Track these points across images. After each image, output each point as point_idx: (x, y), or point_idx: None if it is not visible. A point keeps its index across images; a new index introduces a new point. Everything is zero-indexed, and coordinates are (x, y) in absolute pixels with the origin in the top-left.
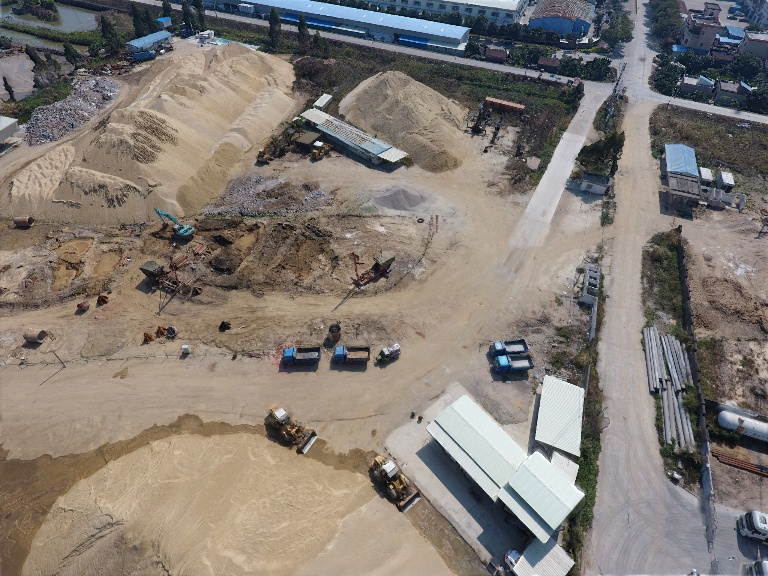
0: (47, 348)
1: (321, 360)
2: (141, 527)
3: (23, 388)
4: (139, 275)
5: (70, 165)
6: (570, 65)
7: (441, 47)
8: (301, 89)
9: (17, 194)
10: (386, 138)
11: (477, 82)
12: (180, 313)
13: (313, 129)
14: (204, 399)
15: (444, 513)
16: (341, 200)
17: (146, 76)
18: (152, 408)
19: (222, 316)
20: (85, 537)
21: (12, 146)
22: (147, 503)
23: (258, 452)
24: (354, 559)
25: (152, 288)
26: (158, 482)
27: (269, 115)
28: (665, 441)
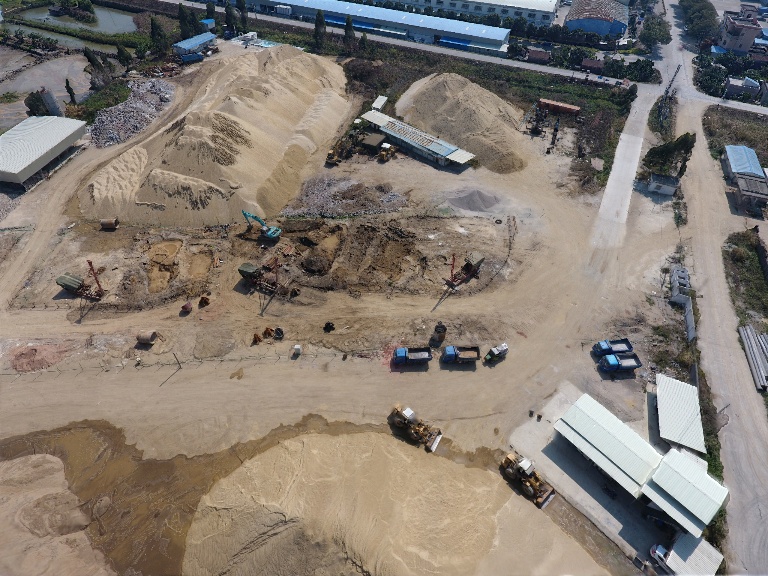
0: (159, 349)
1: (430, 360)
2: (319, 524)
3: (144, 389)
4: (234, 276)
5: (147, 167)
6: (615, 66)
7: (483, 48)
8: (354, 91)
9: (99, 196)
10: (449, 140)
11: (525, 83)
12: (282, 314)
13: (374, 131)
14: (324, 399)
15: (581, 509)
16: (416, 201)
17: (198, 78)
18: (275, 408)
19: (324, 317)
20: (255, 535)
21: (81, 148)
22: (313, 501)
23: (392, 451)
24: (521, 554)
25: (251, 289)
26: (313, 480)
27: (329, 117)
28: None
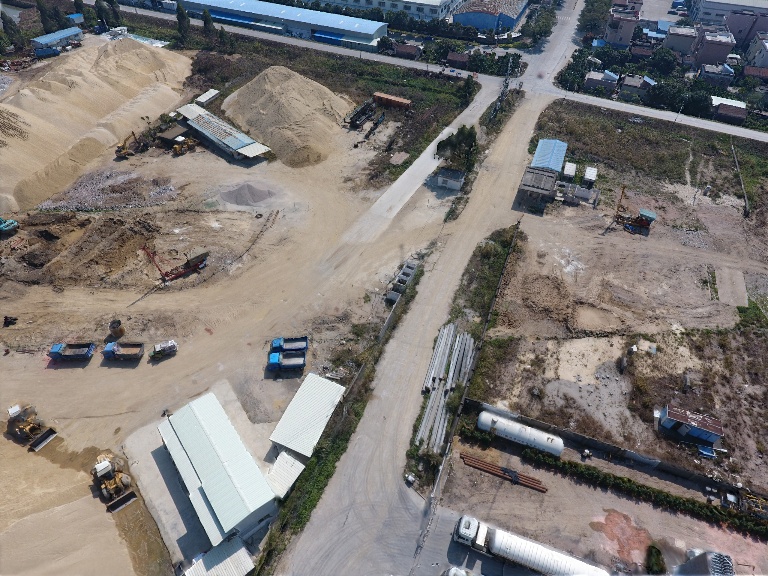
0: None
1: (94, 356)
2: None
3: None
4: None
5: None
6: (477, 60)
7: (354, 43)
8: (193, 84)
9: None
10: (257, 133)
11: (377, 77)
12: None
13: (187, 124)
14: None
15: (154, 514)
16: (187, 195)
17: (42, 72)
18: None
19: (12, 311)
20: None
21: None
22: None
23: None
24: None
25: None
26: None
27: (146, 110)
28: (414, 442)
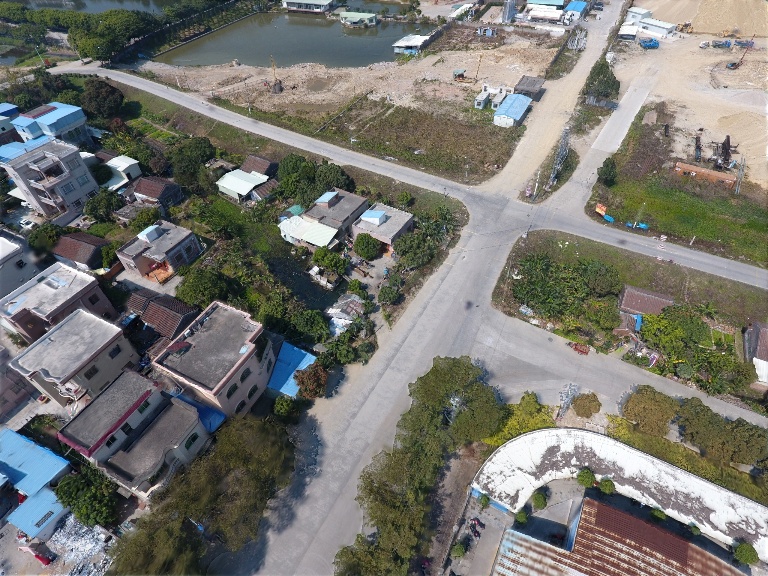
0: None
1: None
2: None
3: None
4: None
5: None
6: None
7: None
8: None
9: None
10: None
11: None
12: None
13: None
14: None
15: None
16: None
17: None
18: None
19: None
20: None
21: None
22: (758, 2)
23: None
24: (691, 5)
25: None
26: (761, 11)
27: None
28: None
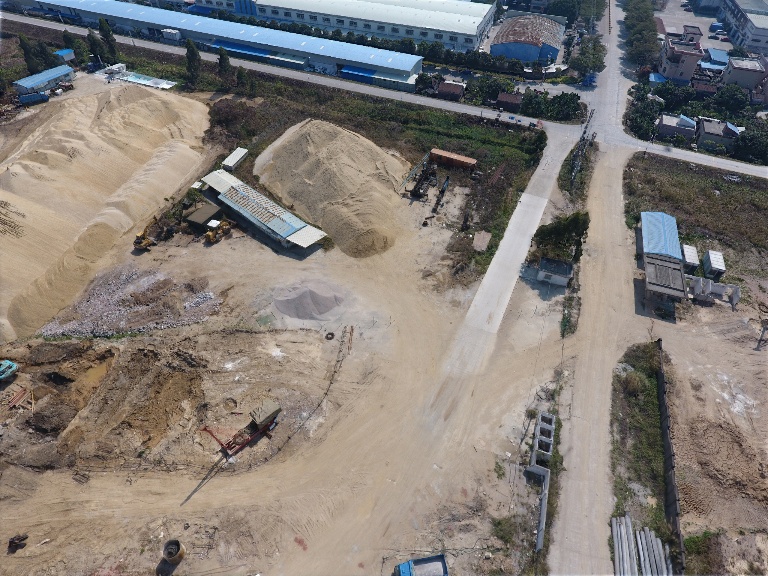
0: None
1: None
2: None
3: None
4: None
5: None
6: (533, 102)
7: (389, 80)
8: (214, 140)
9: None
10: (304, 209)
11: (425, 126)
12: None
13: (216, 197)
14: None
15: None
16: (232, 305)
17: (30, 125)
18: None
19: (19, 522)
20: None
21: None
22: None
23: None
24: None
25: None
26: None
27: (164, 179)
28: None
